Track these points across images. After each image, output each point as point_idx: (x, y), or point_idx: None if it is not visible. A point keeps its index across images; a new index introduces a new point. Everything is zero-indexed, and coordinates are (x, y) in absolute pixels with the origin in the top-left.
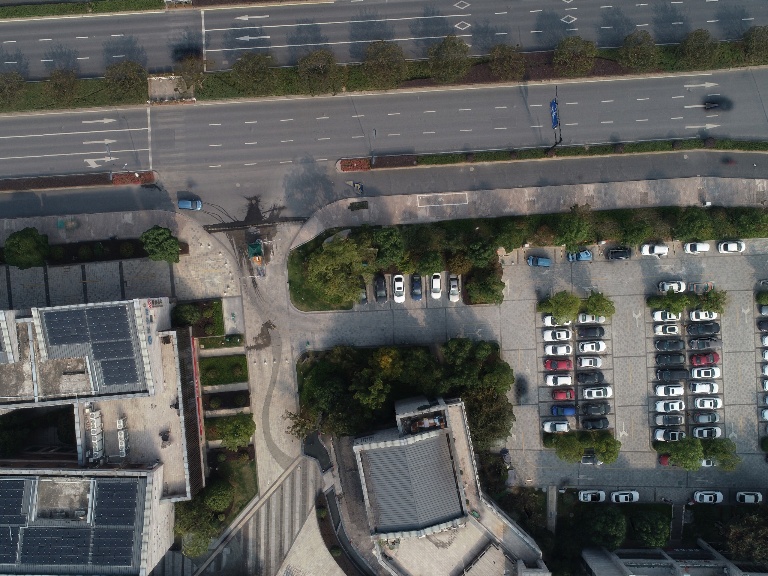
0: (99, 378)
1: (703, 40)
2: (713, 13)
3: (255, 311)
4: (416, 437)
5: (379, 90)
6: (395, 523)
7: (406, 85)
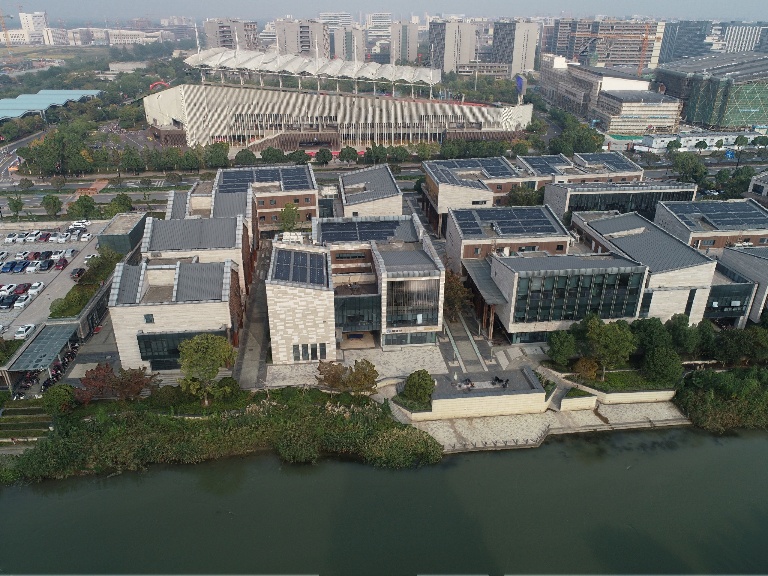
0: (614, 168)
1: (764, 149)
2: (759, 159)
3: None
4: None
5: (650, 170)
6: None
7: (660, 167)
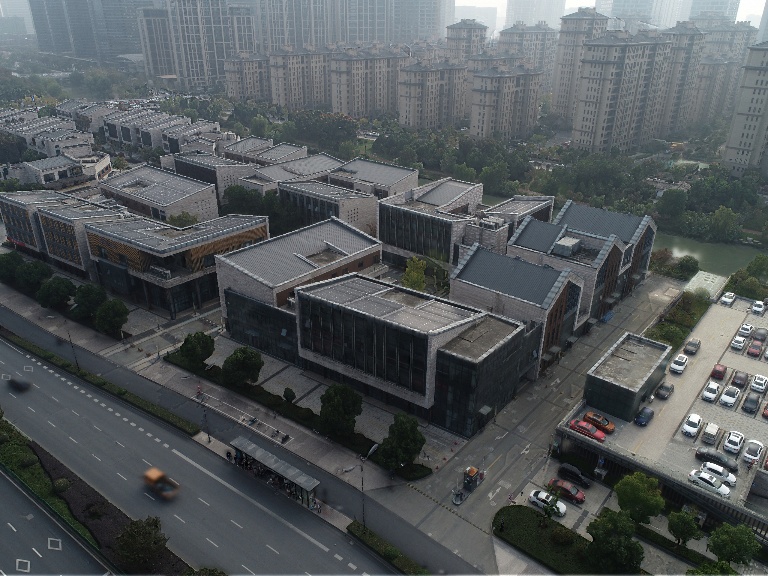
0: None
1: None
2: None
3: (2, 239)
4: (19, 163)
5: None
6: (68, 160)
7: None
